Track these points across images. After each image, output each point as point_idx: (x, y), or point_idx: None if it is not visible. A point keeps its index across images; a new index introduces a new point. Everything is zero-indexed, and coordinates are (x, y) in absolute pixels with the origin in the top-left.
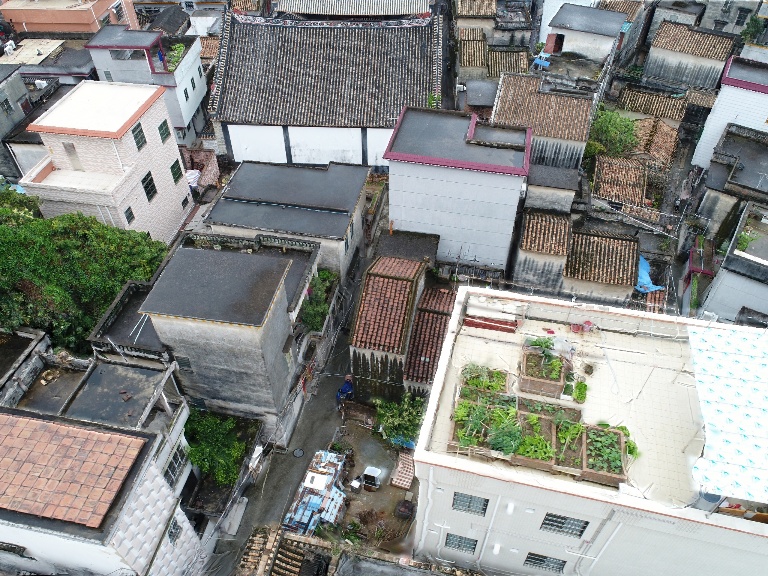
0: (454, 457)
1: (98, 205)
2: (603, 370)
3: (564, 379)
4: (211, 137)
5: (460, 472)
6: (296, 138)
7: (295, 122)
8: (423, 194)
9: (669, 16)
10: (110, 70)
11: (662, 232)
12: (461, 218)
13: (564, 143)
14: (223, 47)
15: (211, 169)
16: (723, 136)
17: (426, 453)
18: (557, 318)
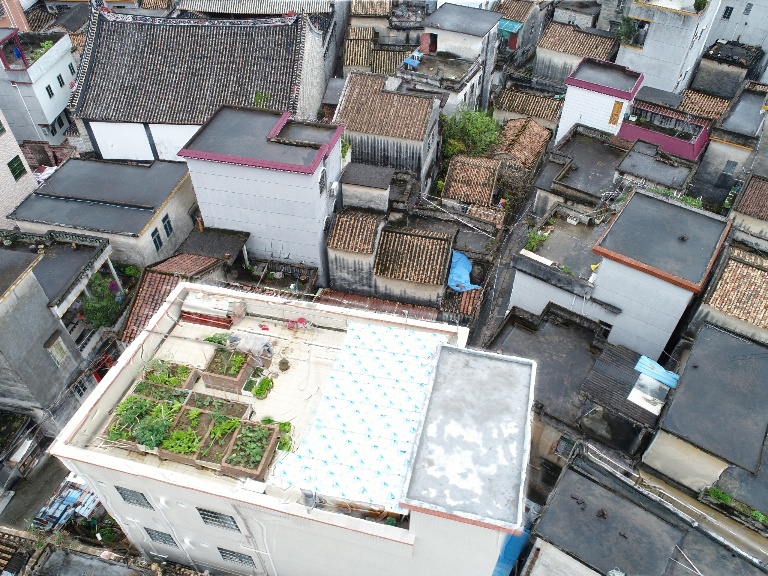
0: (89, 451)
1: None
2: (300, 367)
3: (245, 375)
4: (75, 134)
5: (91, 465)
6: (159, 135)
7: (155, 119)
8: (225, 191)
9: (568, 16)
10: None
11: (481, 231)
12: (266, 216)
13: (403, 142)
14: (88, 44)
15: None
16: (565, 136)
17: (63, 446)
18: (275, 315)
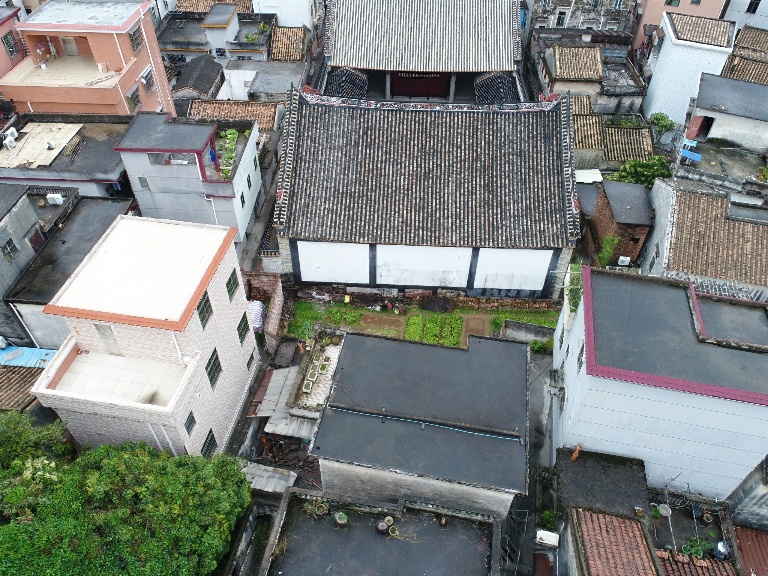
0: None
1: (148, 422)
2: None
3: None
4: (274, 254)
5: None
6: (385, 257)
7: (387, 240)
8: (633, 414)
9: None
10: (147, 176)
11: None
12: (682, 444)
13: (767, 291)
14: (290, 137)
15: (276, 301)
16: None
17: None
18: None
